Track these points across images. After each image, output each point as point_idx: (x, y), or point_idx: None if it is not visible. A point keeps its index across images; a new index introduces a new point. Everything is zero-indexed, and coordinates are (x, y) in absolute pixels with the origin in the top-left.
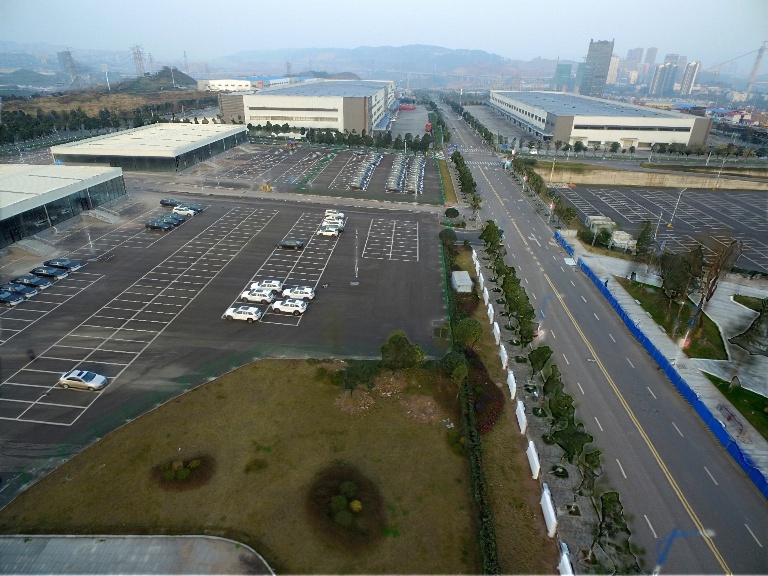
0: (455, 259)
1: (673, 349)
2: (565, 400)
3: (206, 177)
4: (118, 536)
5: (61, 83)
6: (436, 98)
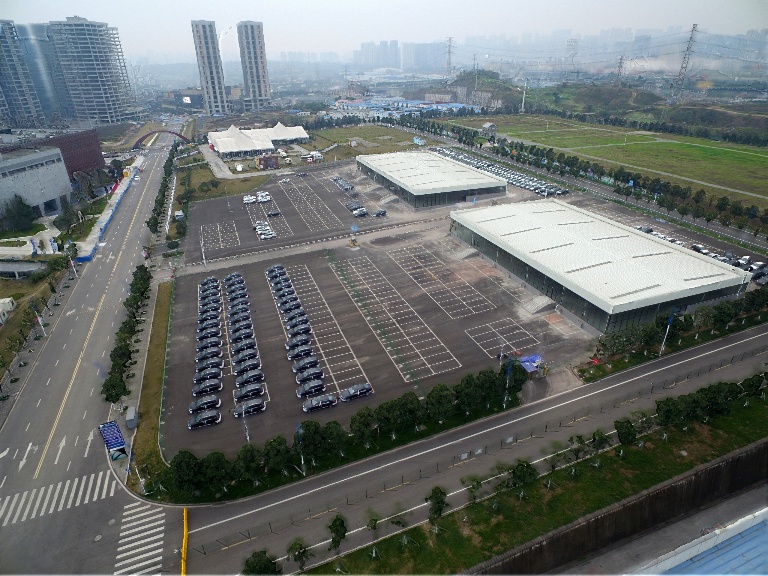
0: None
1: (102, 217)
2: None
3: (428, 241)
4: None
5: None
6: None
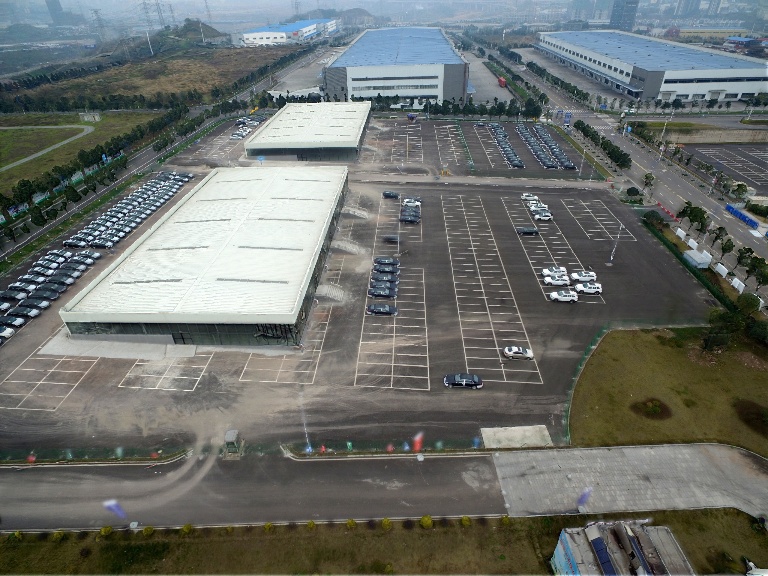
0: (666, 237)
1: None
2: None
3: (382, 163)
4: (659, 445)
5: (92, 45)
6: (485, 44)
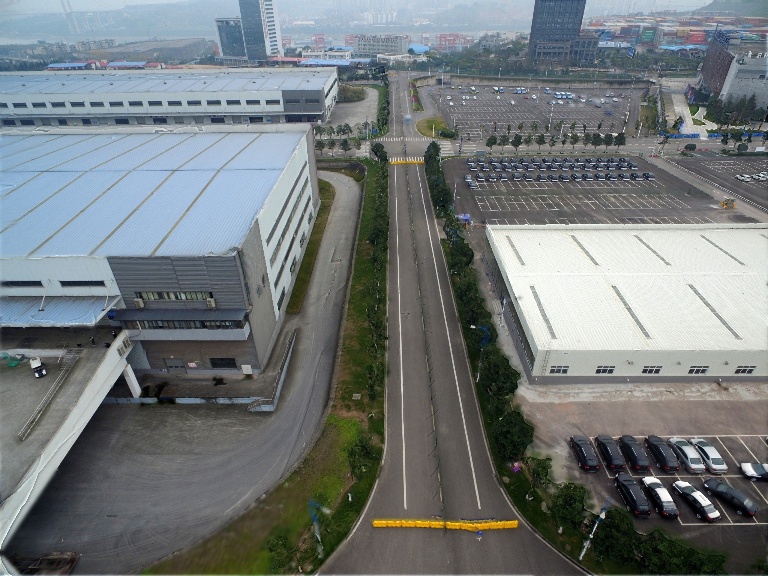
0: None
1: None
2: None
3: None
4: None
5: None
6: None
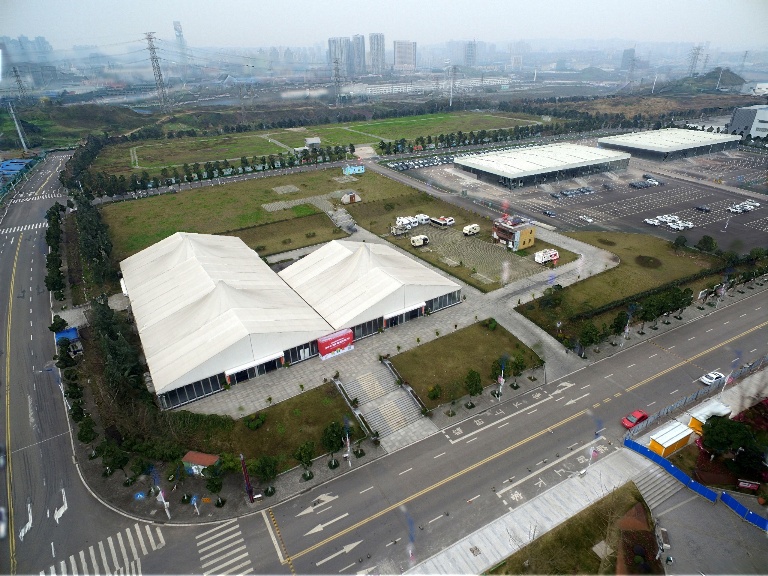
0: None
1: None
2: (759, 267)
3: (681, 168)
4: (586, 243)
5: (617, 84)
6: None
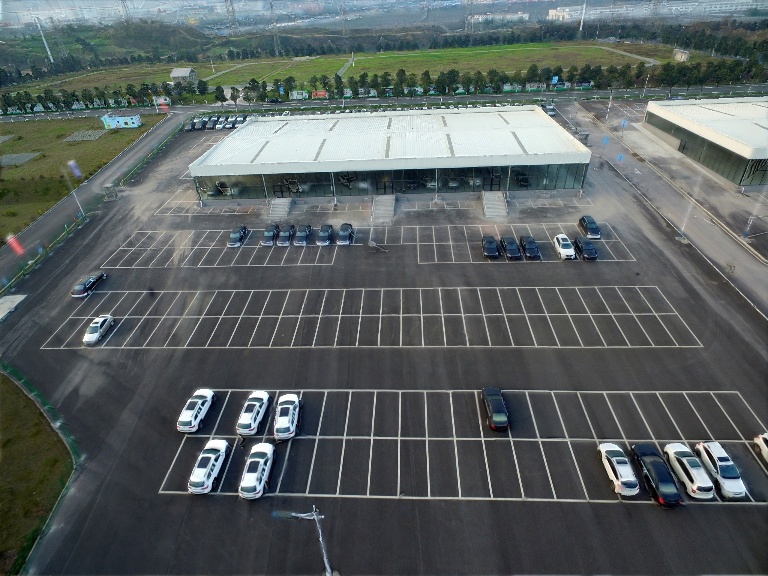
0: None
1: None
2: None
3: None
4: None
5: None
6: None
